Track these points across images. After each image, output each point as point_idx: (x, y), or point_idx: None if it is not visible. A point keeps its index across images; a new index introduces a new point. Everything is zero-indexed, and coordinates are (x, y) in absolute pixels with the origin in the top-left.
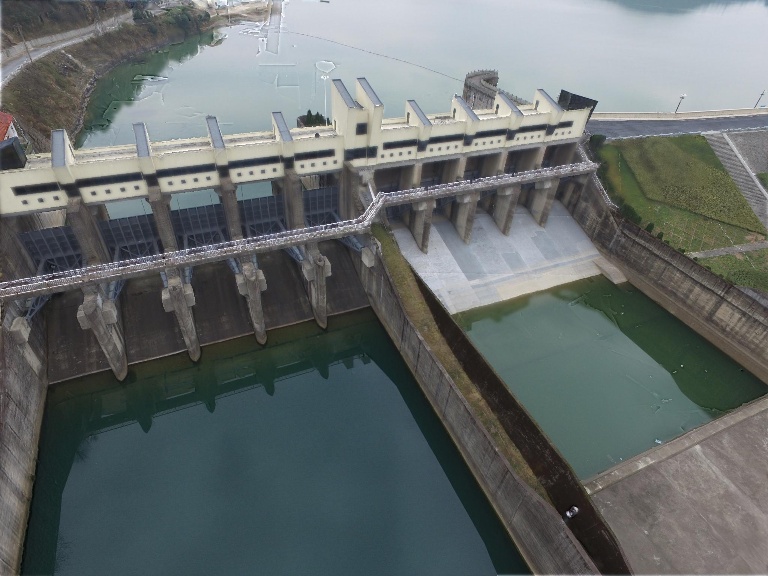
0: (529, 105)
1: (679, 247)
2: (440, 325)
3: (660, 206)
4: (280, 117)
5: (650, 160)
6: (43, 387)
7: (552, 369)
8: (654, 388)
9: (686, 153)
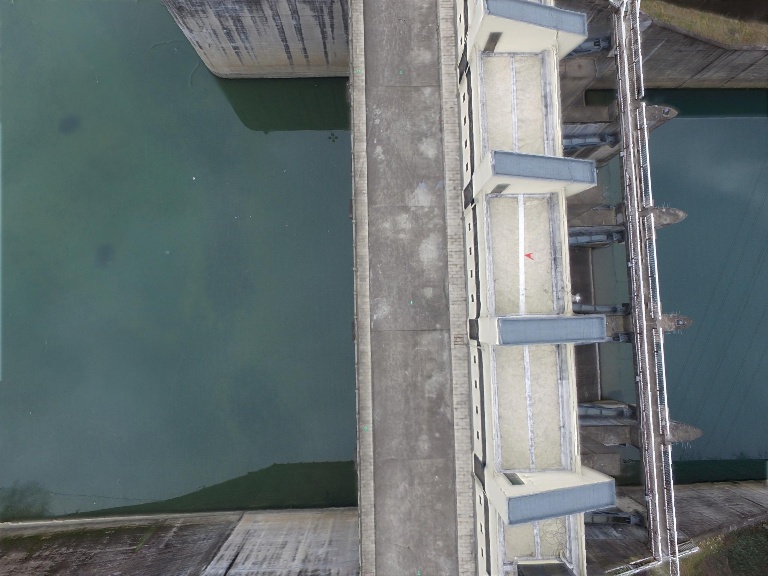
0: None
1: None
2: (742, 16)
3: None
4: (502, 4)
5: None
6: (623, 490)
7: None
8: None
9: None
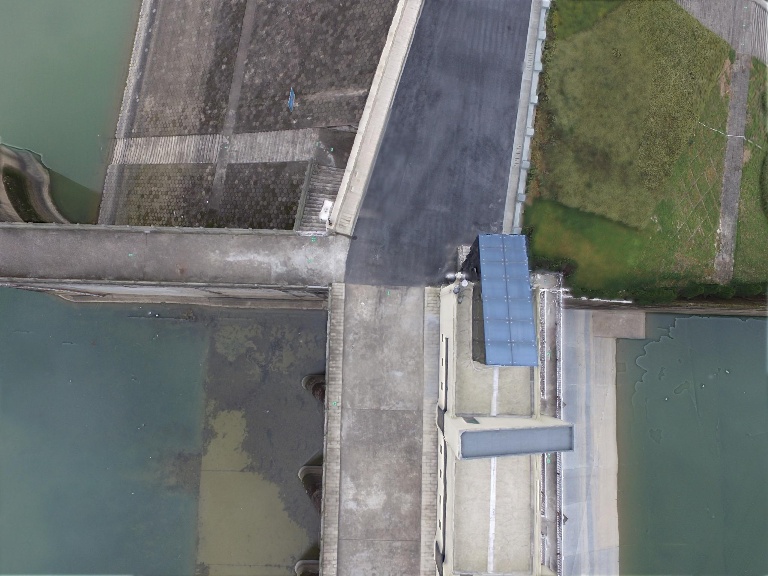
0: (454, 464)
1: (708, 245)
2: None
3: (656, 215)
4: None
5: (591, 146)
6: None
7: (757, 570)
8: (766, 407)
9: (595, 28)
